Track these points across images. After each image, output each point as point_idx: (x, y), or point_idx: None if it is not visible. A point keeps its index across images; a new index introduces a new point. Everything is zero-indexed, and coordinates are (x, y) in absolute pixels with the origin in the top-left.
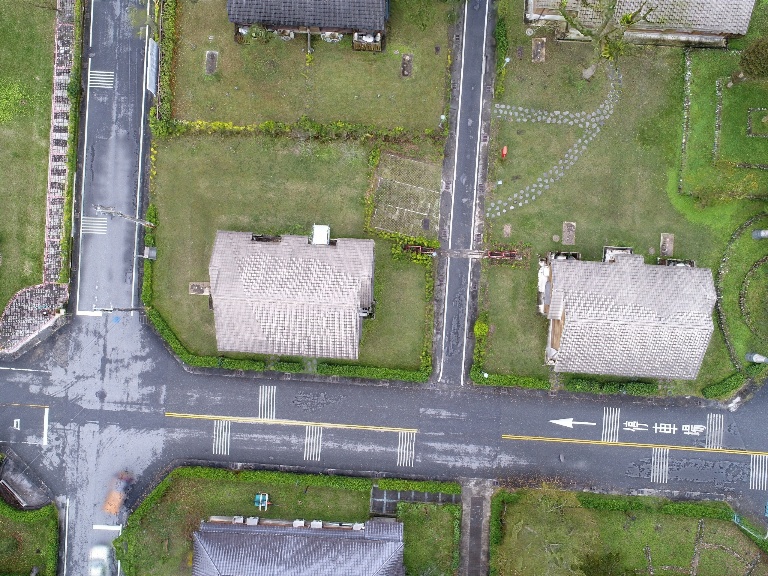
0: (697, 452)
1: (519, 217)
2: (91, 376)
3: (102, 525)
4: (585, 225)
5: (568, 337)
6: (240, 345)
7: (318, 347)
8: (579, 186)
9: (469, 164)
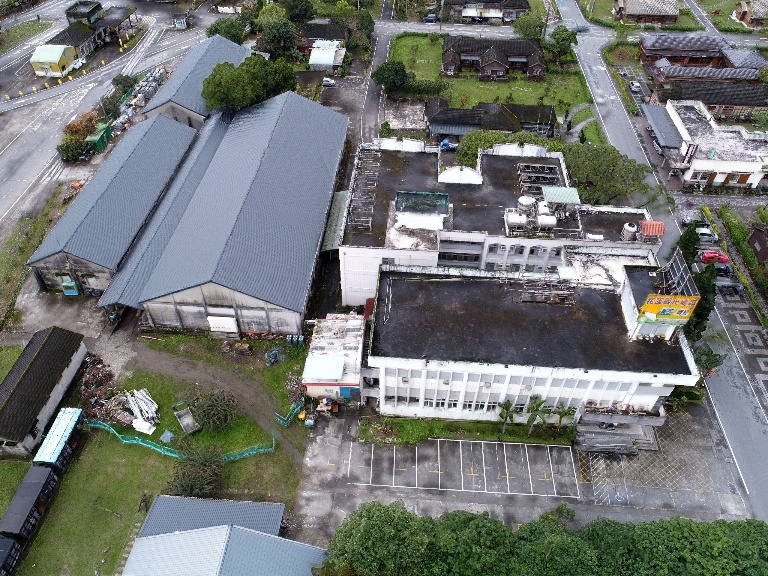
0: None
1: (715, 9)
2: None
3: (591, 53)
4: None
5: (754, 6)
6: (635, 11)
7: (664, 11)
8: (732, 5)
9: (691, 2)
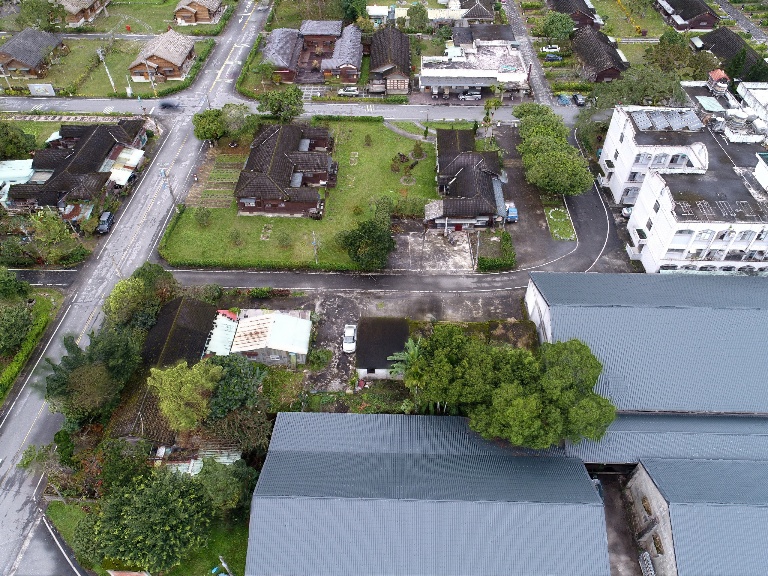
0: (258, 2)
1: None
2: (184, 109)
3: None
4: (166, 19)
5: (201, 3)
6: (179, 60)
7: (187, 45)
8: None
9: None
